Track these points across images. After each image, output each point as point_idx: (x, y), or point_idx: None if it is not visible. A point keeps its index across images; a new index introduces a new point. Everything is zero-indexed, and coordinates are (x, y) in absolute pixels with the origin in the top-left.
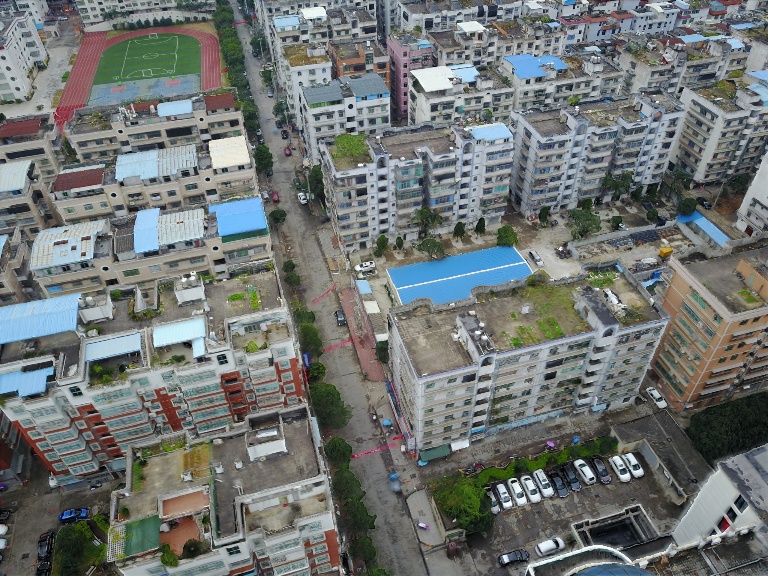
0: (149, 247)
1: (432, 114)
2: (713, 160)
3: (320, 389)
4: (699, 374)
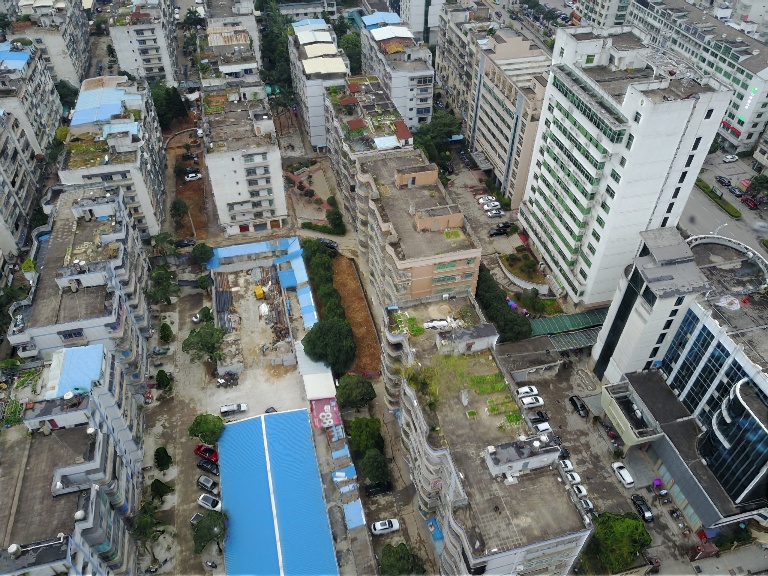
0: None
1: None
2: (153, 208)
3: None
4: None
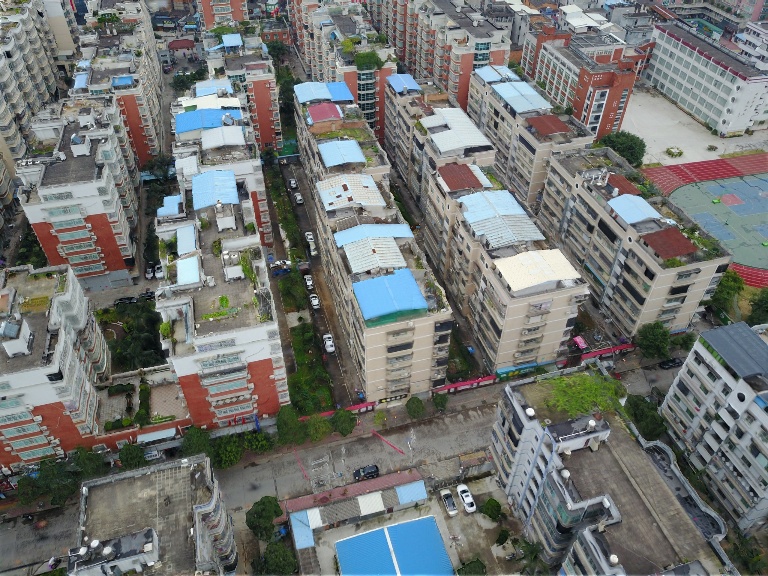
0: (340, 240)
1: None
2: None
3: (192, 429)
4: None
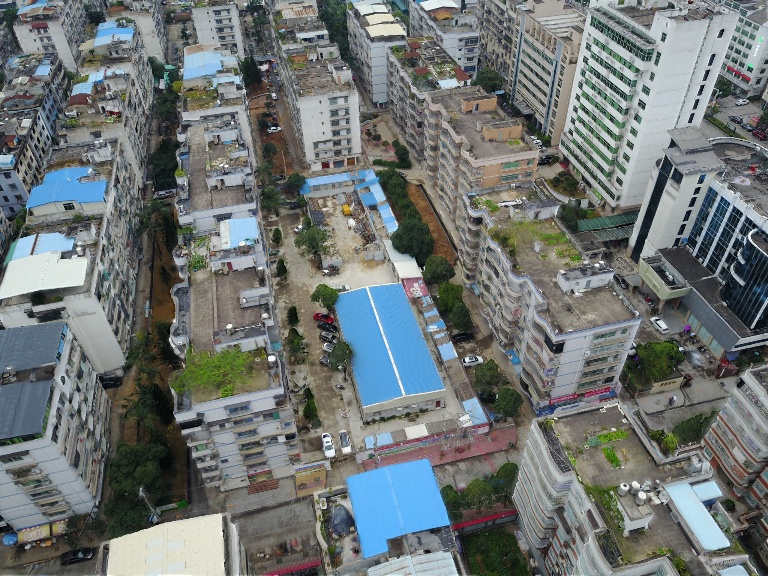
0: None
1: (100, 304)
2: (252, 147)
3: None
4: None
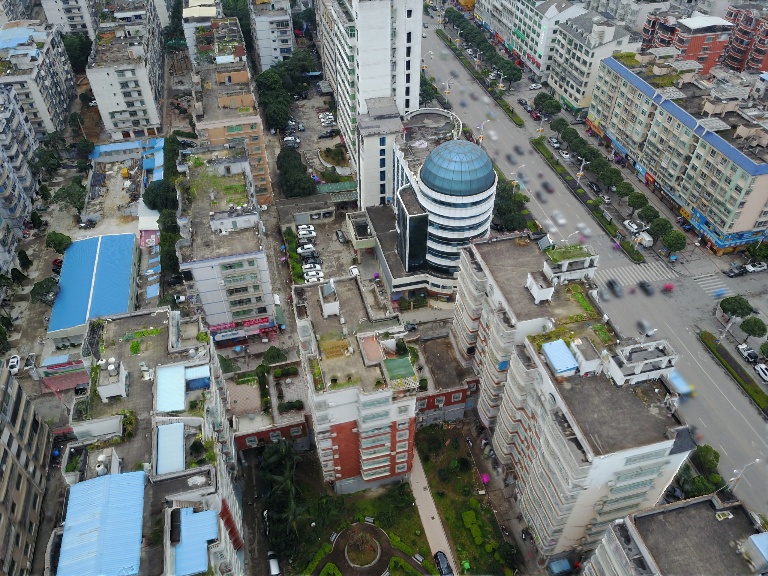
0: None
1: None
2: (50, 115)
3: None
4: (267, 168)
